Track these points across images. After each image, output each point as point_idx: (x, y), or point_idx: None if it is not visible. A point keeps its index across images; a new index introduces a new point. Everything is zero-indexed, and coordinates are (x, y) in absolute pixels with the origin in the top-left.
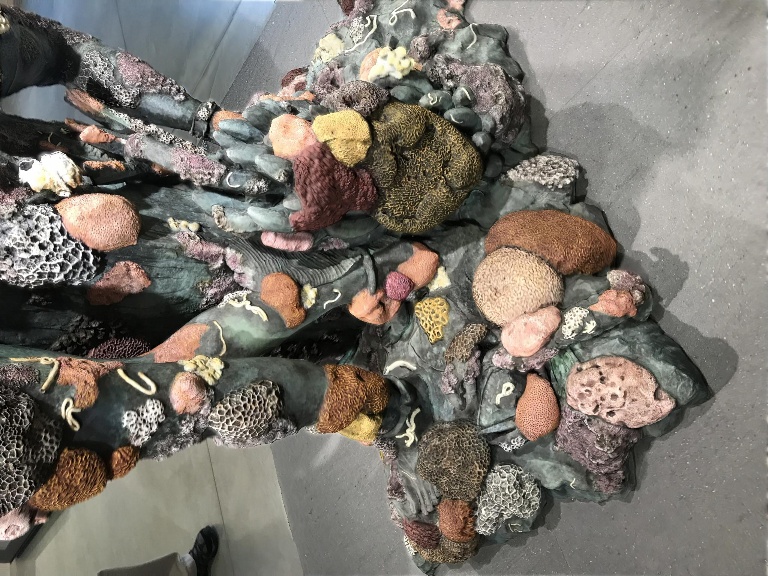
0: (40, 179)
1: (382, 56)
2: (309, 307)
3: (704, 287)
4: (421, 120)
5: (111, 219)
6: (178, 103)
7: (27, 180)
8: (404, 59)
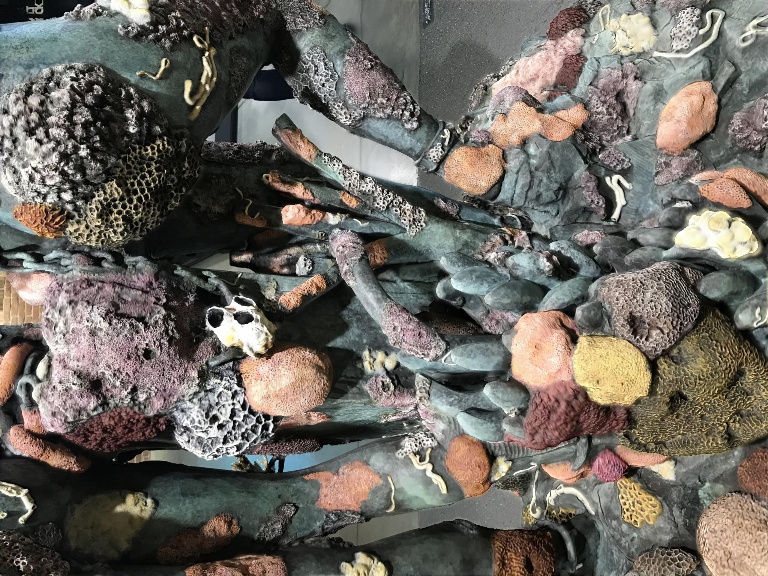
0: (228, 338)
1: (711, 228)
2: (497, 479)
3: None
4: (730, 373)
5: (299, 396)
6: (408, 132)
7: (214, 331)
8: (743, 244)
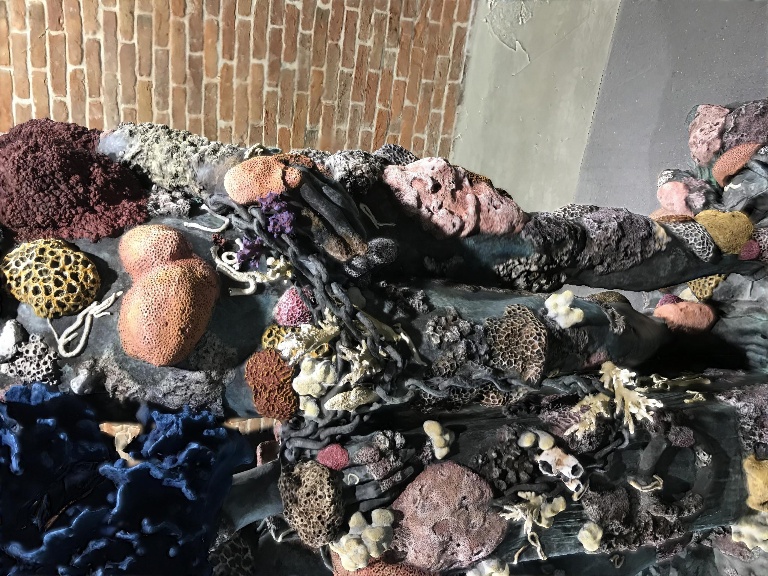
0: None
1: None
2: None
3: (682, 165)
4: None
5: None
6: None
7: None
8: None
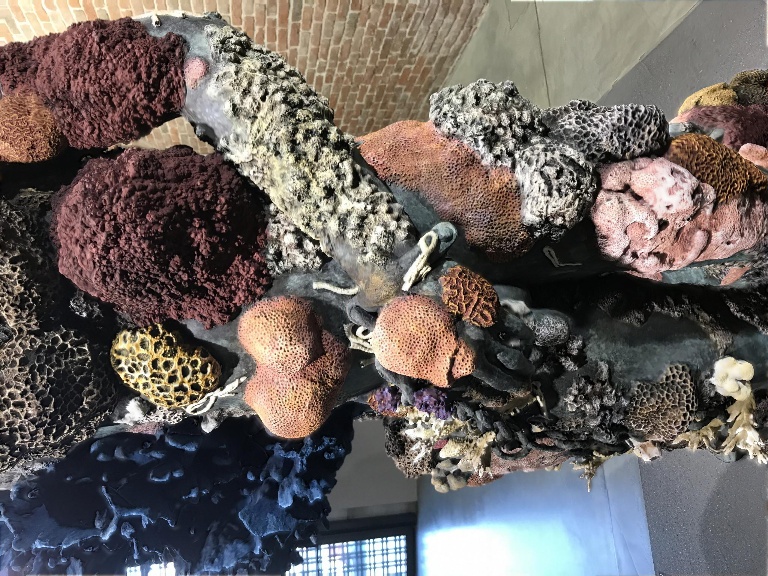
0: None
1: None
2: None
3: None
4: None
5: None
6: None
7: None
8: None
